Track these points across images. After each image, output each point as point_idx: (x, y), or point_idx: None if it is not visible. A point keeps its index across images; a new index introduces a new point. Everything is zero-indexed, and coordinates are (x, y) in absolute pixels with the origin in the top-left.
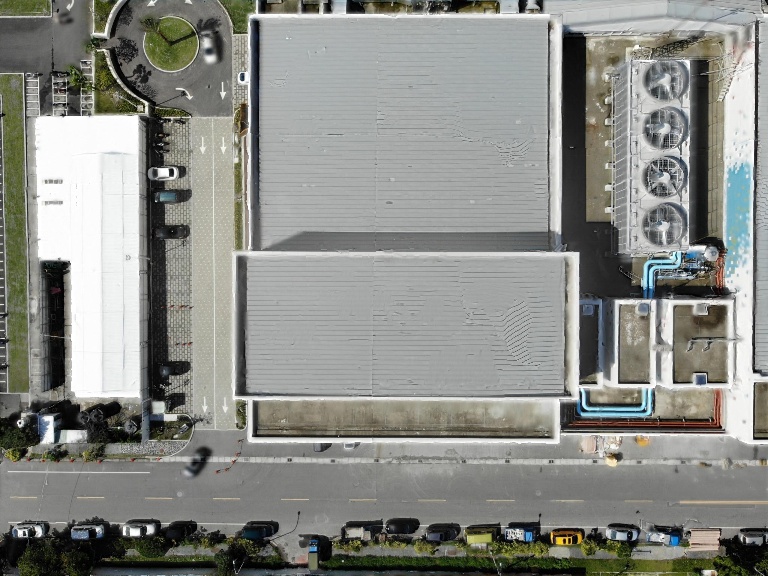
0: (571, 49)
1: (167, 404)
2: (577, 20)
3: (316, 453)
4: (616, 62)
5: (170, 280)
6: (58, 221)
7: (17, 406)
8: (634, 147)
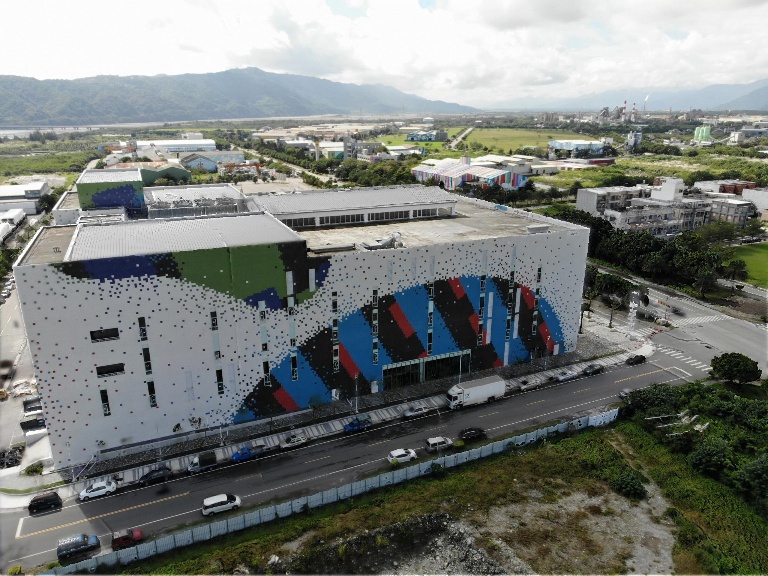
0: None
1: None
2: None
3: None
4: None
5: None
6: None
7: None
8: None
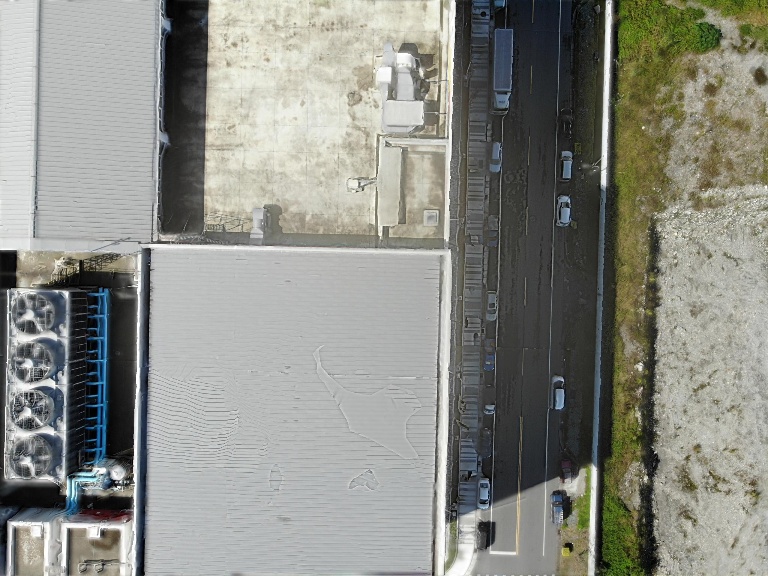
0: (0, 258)
1: None
2: None
3: None
4: (44, 273)
5: None
6: None
7: None
8: (11, 375)
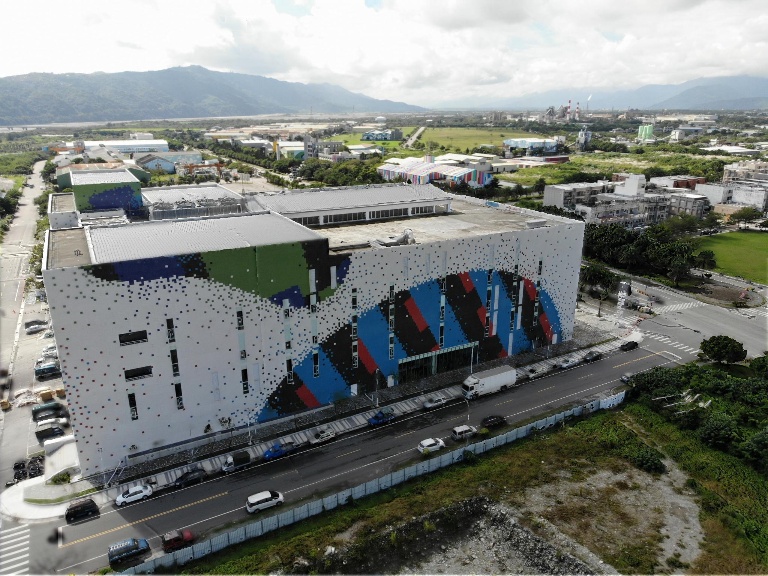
0: None
1: None
2: None
3: None
4: None
5: None
6: None
7: None
8: None
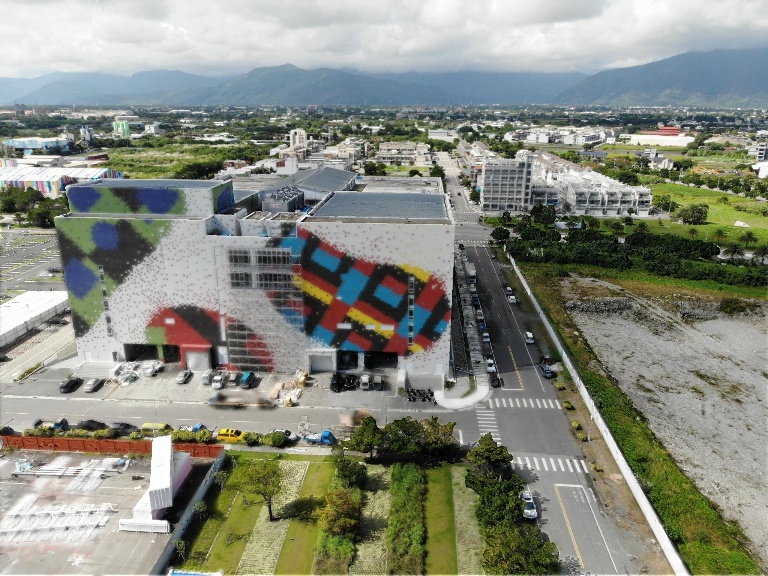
0: None
1: None
2: (268, 190)
3: (59, 395)
4: None
5: (38, 335)
6: (0, 310)
7: None
8: None
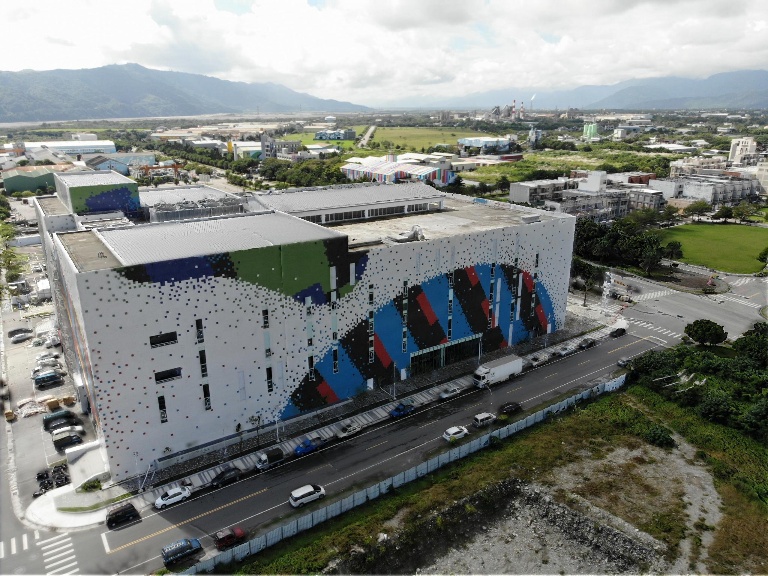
0: None
1: (36, 301)
2: None
3: None
4: None
5: None
6: None
7: (29, 284)
8: None
